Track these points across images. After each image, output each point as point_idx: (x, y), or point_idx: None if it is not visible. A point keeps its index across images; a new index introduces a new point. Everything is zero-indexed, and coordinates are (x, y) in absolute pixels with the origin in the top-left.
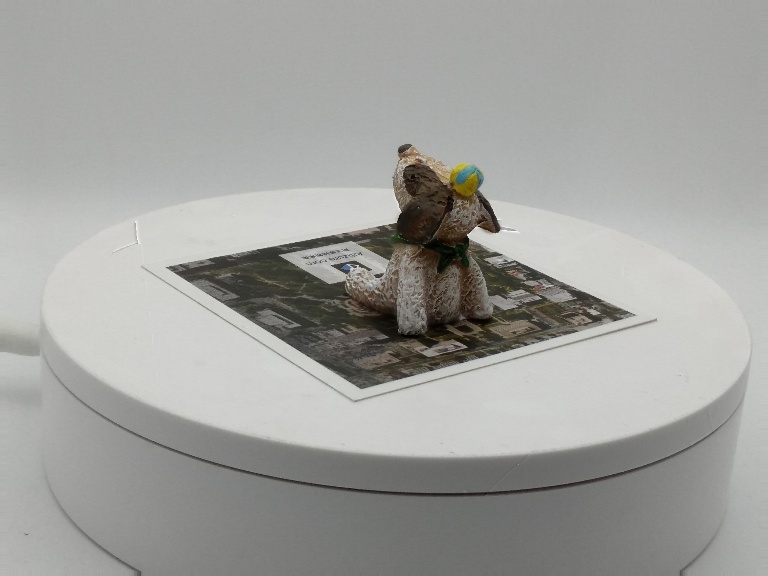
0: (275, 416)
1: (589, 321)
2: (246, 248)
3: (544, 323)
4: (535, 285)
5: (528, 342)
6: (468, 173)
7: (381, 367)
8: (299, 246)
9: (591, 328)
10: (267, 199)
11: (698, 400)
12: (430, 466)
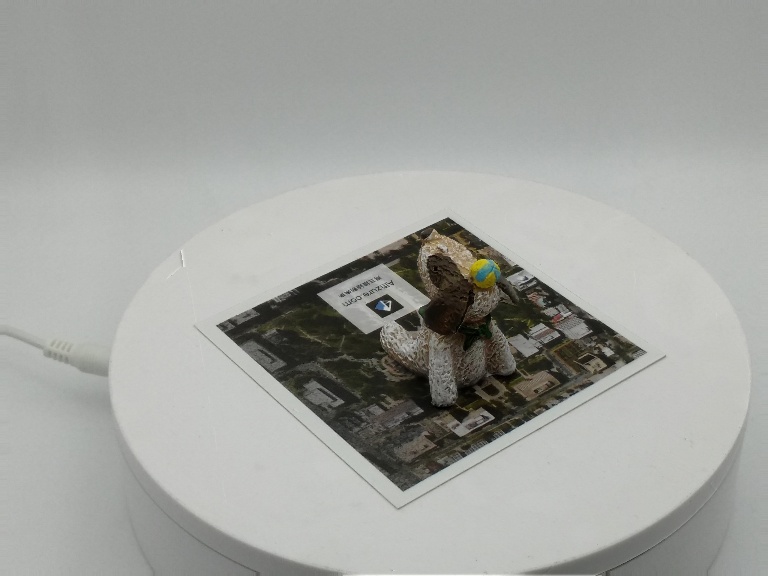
0: (330, 537)
1: (604, 366)
2: (286, 287)
3: (563, 374)
4: (554, 315)
5: (549, 404)
6: (486, 272)
7: (419, 457)
8: (335, 277)
9: (606, 377)
10: (300, 202)
11: (701, 473)
12: None
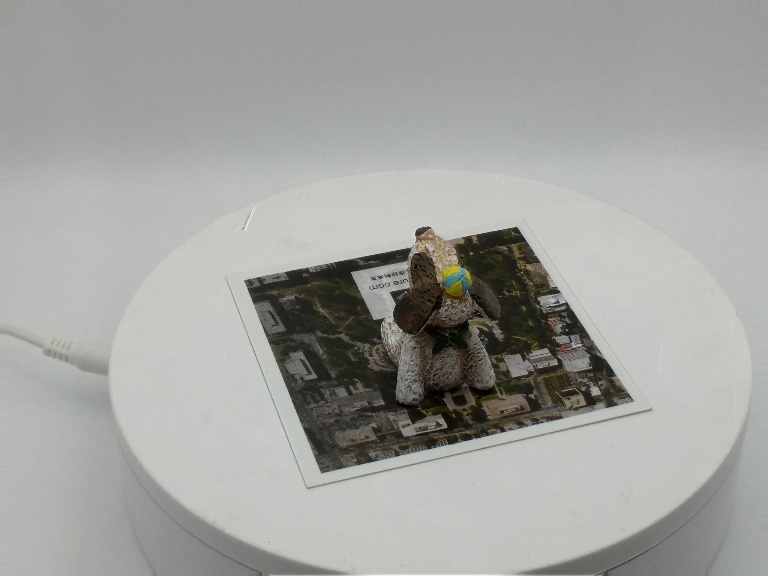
0: (233, 497)
1: (582, 404)
2: (327, 259)
3: (538, 402)
4: (564, 343)
5: (506, 428)
6: (453, 280)
7: (354, 445)
8: (376, 260)
9: (578, 415)
10: (387, 183)
11: (618, 532)
12: None
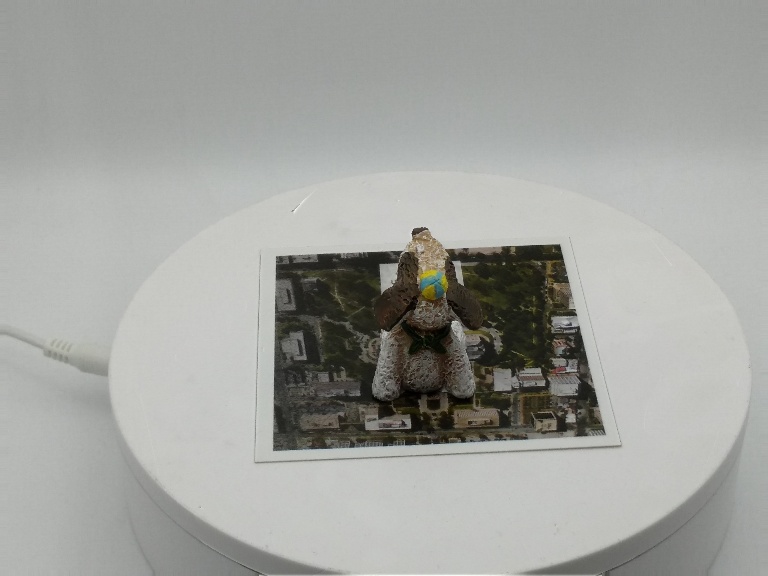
0: (183, 458)
1: (552, 429)
2: (362, 248)
3: (509, 419)
4: (559, 366)
5: (468, 439)
6: (427, 283)
7: (315, 430)
8: None
9: (544, 439)
10: (450, 183)
11: (537, 560)
12: (248, 551)
